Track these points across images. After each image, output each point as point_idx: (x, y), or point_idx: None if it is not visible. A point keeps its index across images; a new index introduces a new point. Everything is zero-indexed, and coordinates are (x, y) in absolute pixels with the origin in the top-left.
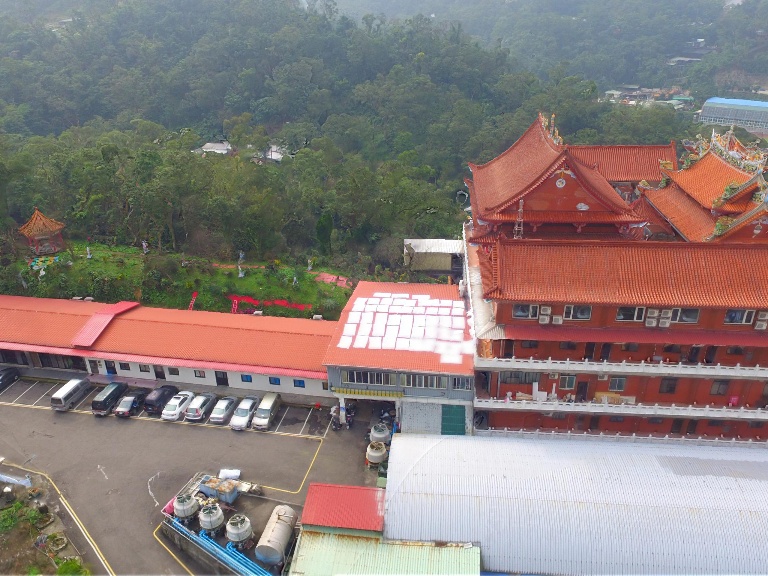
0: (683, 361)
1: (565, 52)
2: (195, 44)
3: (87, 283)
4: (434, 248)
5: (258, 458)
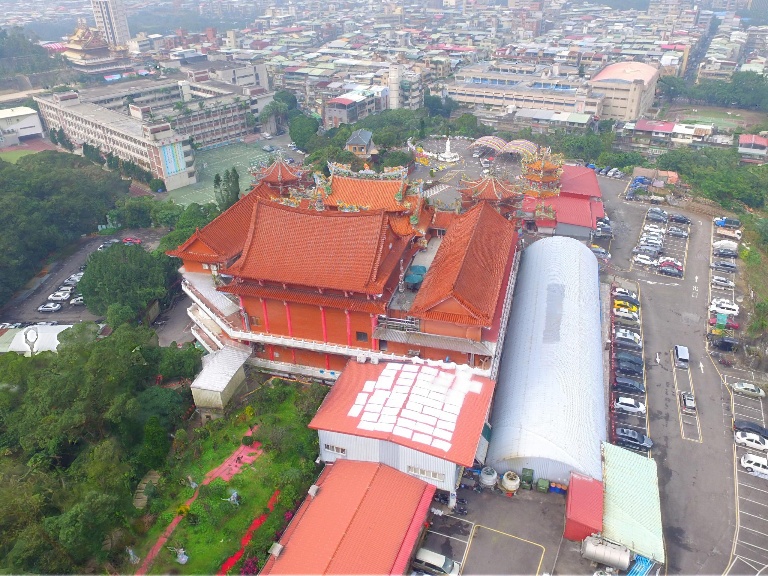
0: None
1: None
2: None
3: None
4: (228, 369)
5: None
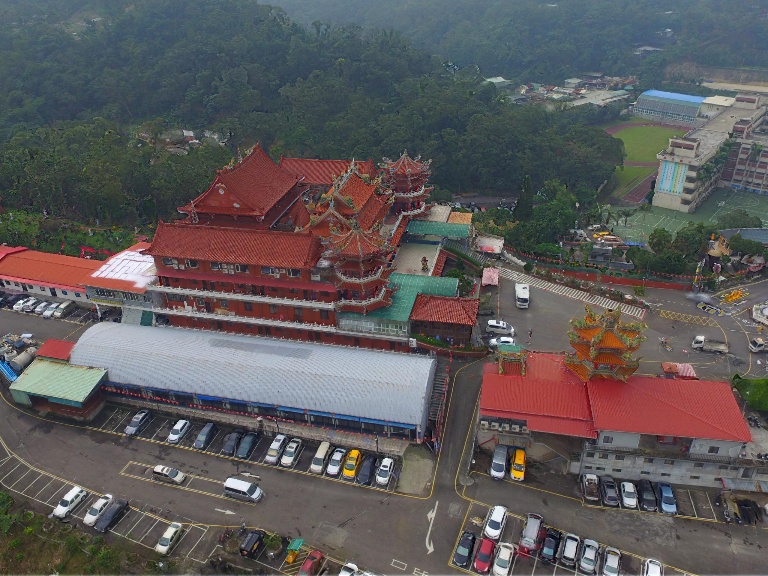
0: (247, 293)
1: (537, 41)
2: (168, 50)
3: (7, 235)
4: None
5: (47, 331)
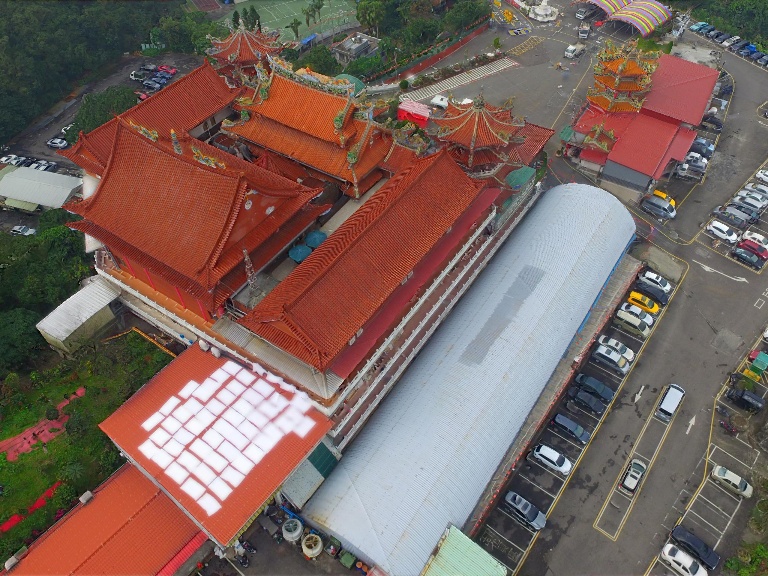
0: (422, 285)
1: None
2: None
3: None
4: (84, 312)
5: None
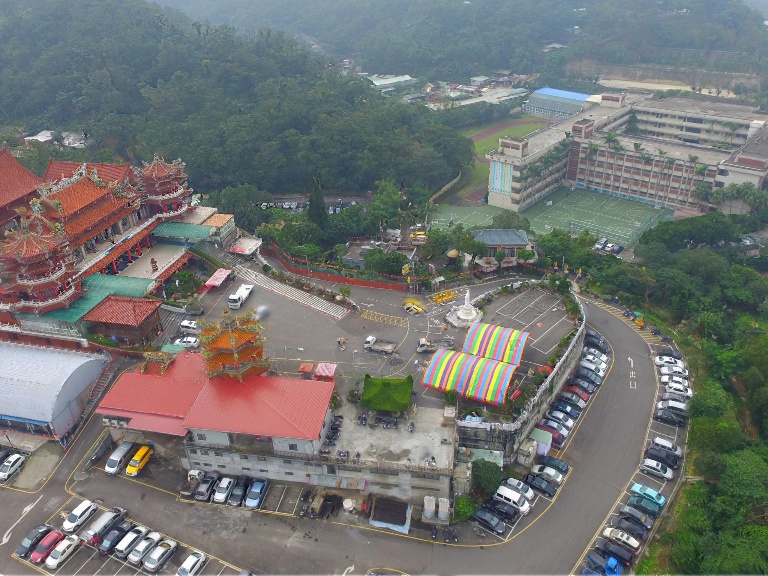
0: None
1: (448, 39)
2: None
3: None
4: None
5: None
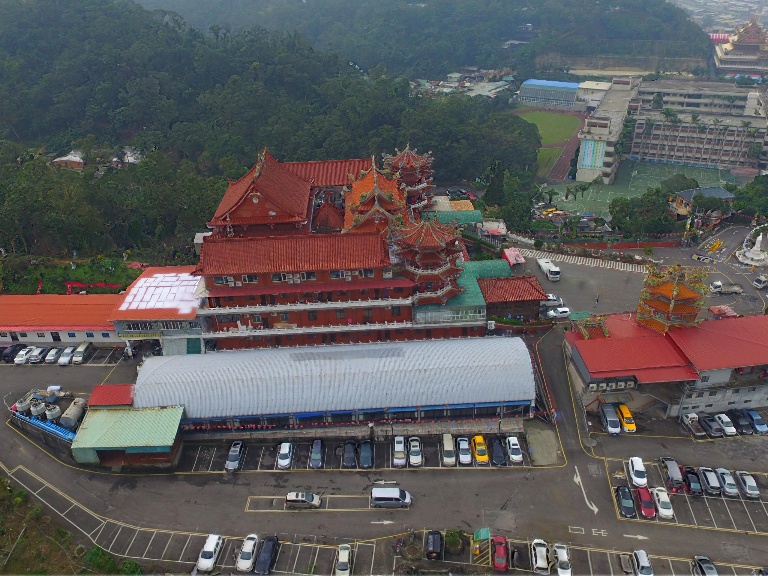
0: (314, 301)
1: (414, 39)
2: (55, 62)
3: None
4: None
5: (74, 379)
